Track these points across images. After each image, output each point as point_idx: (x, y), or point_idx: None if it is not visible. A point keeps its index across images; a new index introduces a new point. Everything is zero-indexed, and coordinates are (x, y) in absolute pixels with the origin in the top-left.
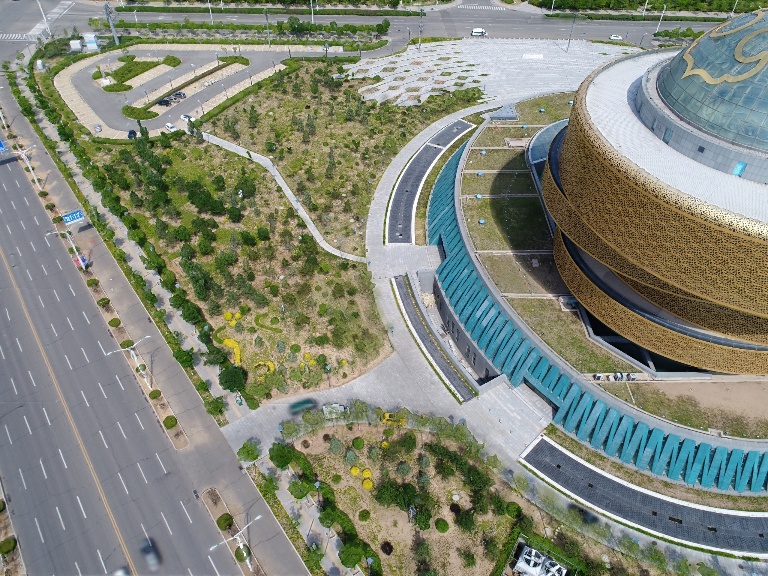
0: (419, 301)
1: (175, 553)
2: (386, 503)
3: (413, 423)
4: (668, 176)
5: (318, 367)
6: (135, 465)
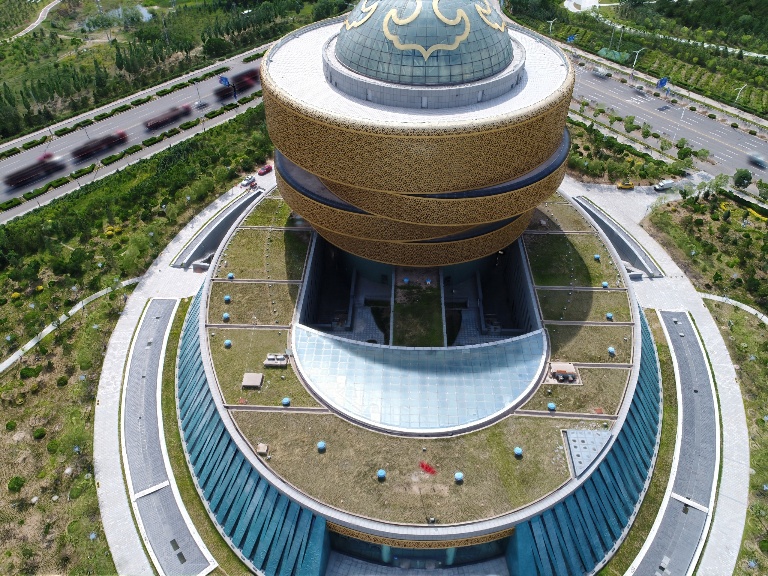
0: (632, 247)
1: (712, 148)
2: (617, 156)
3: (612, 187)
4: (520, 40)
5: (690, 207)
6: (766, 172)
